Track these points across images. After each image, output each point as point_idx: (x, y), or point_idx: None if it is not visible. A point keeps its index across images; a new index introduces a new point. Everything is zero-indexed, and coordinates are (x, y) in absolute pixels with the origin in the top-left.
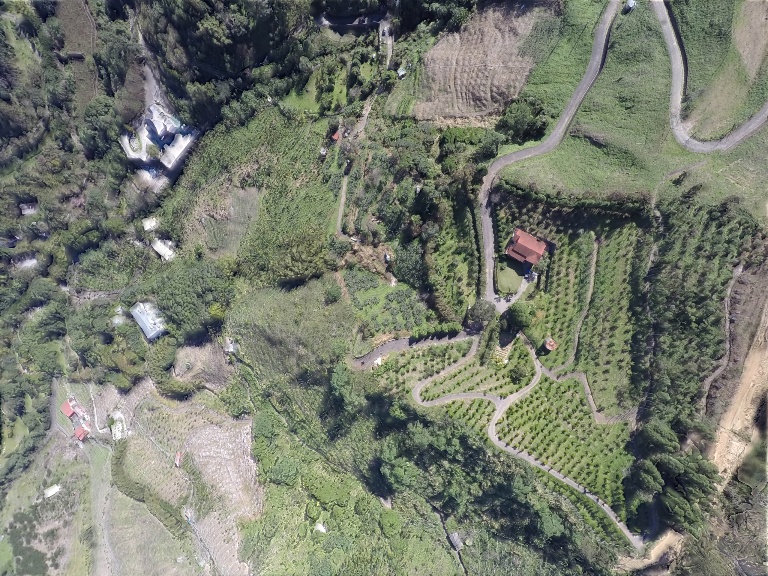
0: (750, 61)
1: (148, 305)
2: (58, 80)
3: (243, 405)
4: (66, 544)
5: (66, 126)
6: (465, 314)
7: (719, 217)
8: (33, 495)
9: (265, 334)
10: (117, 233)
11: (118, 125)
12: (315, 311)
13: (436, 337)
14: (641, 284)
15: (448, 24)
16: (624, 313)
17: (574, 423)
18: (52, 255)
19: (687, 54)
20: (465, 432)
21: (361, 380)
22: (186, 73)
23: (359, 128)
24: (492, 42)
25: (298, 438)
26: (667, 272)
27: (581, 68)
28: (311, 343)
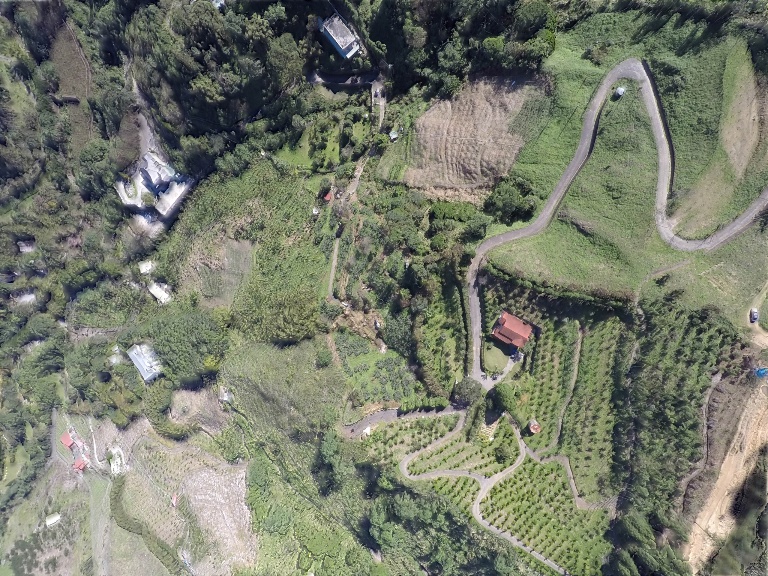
0: (736, 162)
1: (144, 348)
2: (53, 123)
3: (238, 451)
4: (67, 572)
5: (62, 167)
6: (452, 388)
7: (700, 323)
8: (35, 521)
9: (258, 389)
10: (113, 275)
11: (113, 171)
12: (306, 373)
13: (424, 410)
14: (623, 380)
15: (440, 91)
16: (606, 404)
17: (556, 507)
18: (50, 292)
19: (674, 149)
20: (450, 509)
21: (350, 452)
22: (180, 126)
23: (351, 189)
24: (483, 115)
25: (291, 486)
26: (648, 371)
27: (570, 151)
28: (302, 406)
